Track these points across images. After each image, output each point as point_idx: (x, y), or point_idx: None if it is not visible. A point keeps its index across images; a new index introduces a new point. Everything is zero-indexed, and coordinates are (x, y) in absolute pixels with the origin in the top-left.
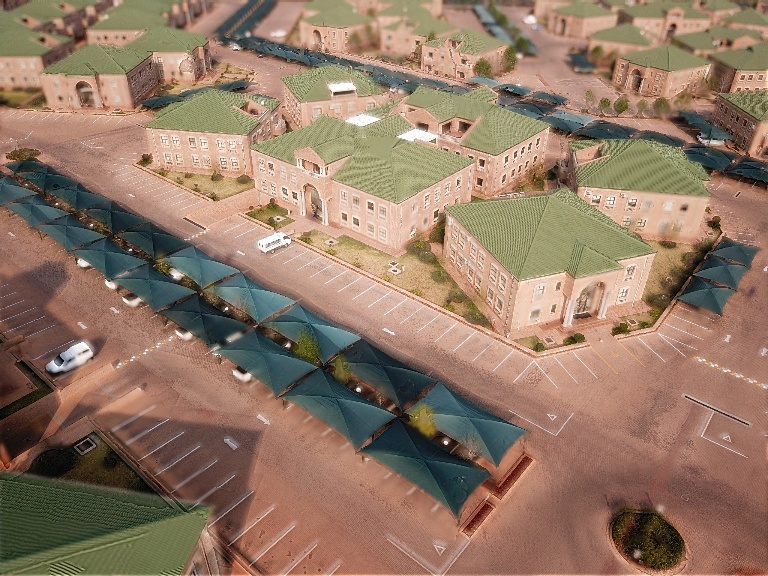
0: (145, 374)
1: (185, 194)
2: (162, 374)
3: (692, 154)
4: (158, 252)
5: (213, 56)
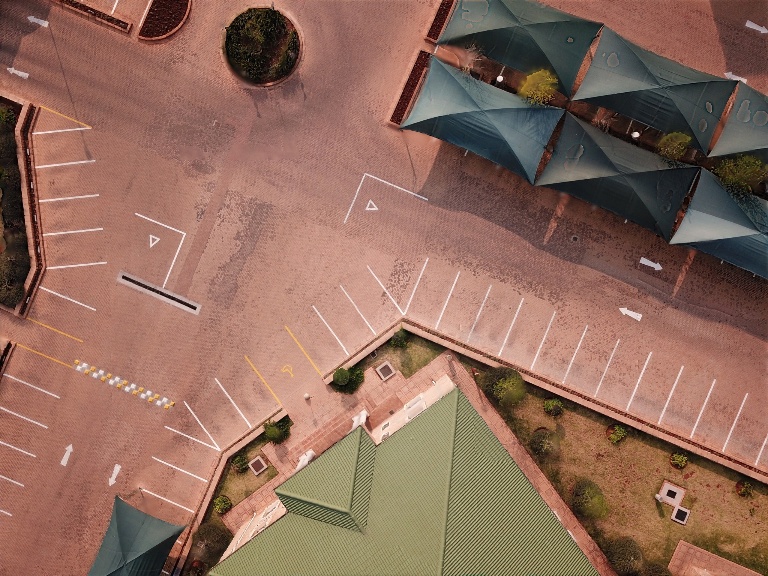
0: None
1: None
2: None
3: None
4: None
5: None
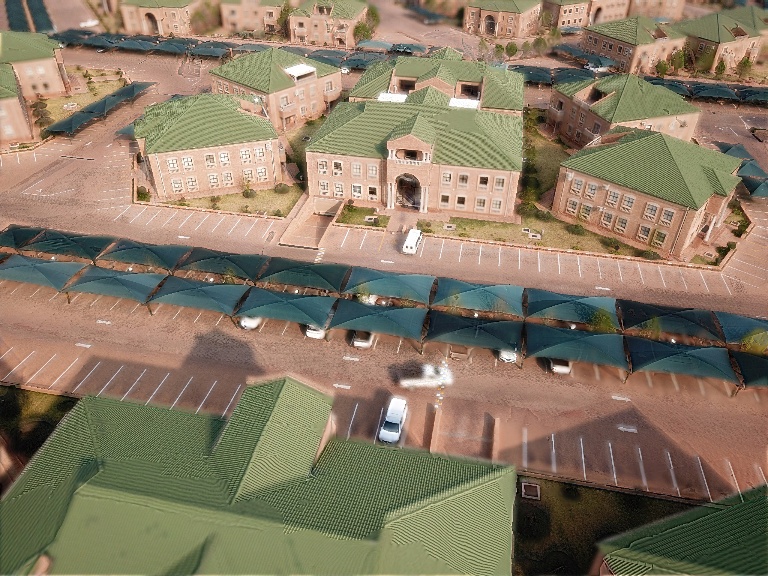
0: (473, 405)
1: (243, 219)
2: (487, 398)
3: None
4: (334, 284)
5: None
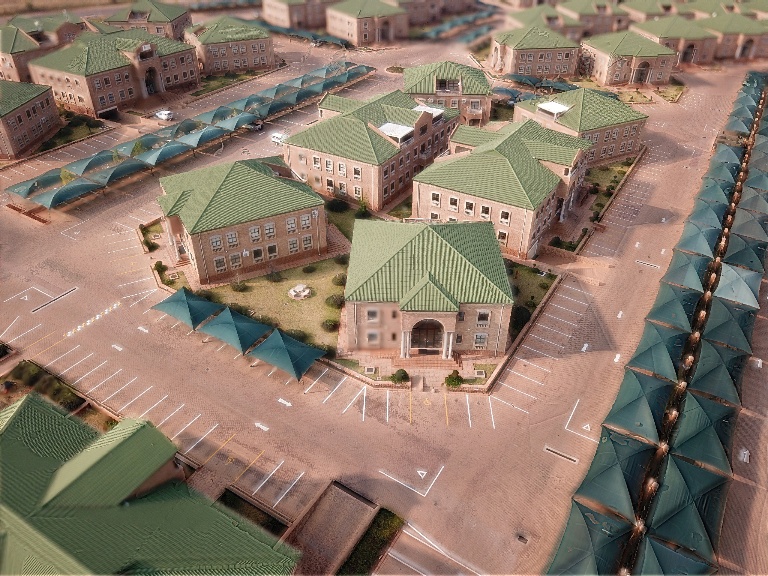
0: None
1: None
2: None
3: (637, 382)
4: None
5: (704, 81)
